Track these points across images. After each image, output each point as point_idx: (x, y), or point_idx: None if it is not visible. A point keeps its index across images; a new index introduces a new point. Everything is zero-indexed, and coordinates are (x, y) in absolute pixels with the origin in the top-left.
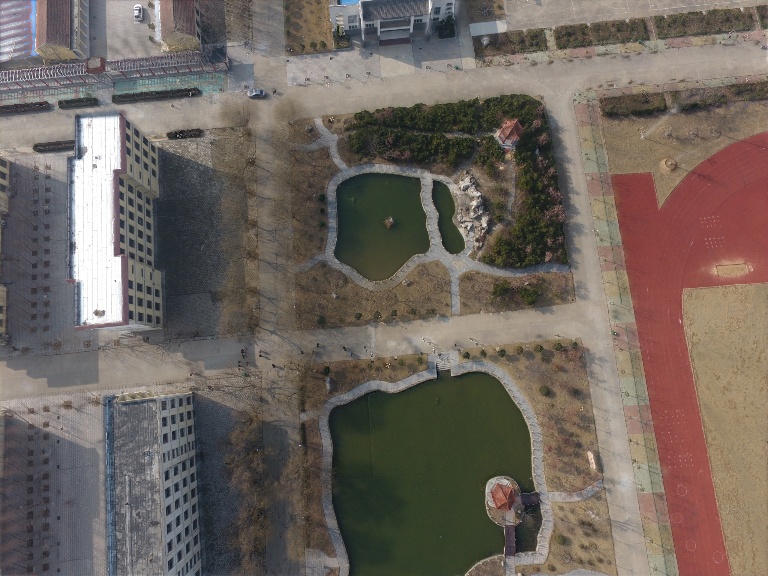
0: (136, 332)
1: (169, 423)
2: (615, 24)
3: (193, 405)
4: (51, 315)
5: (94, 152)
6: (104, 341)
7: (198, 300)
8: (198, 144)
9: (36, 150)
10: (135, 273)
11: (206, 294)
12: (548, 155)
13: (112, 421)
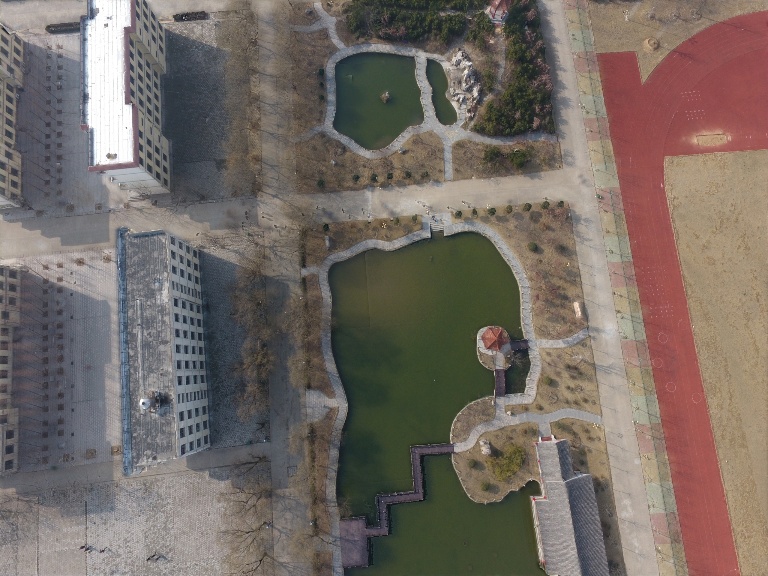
0: (145, 195)
1: (177, 260)
2: None
3: (199, 260)
4: (64, 181)
5: (105, 13)
6: (114, 204)
7: (204, 167)
8: (203, 26)
9: (48, 31)
10: (145, 127)
11: (211, 162)
12: (536, 31)
13: (124, 252)
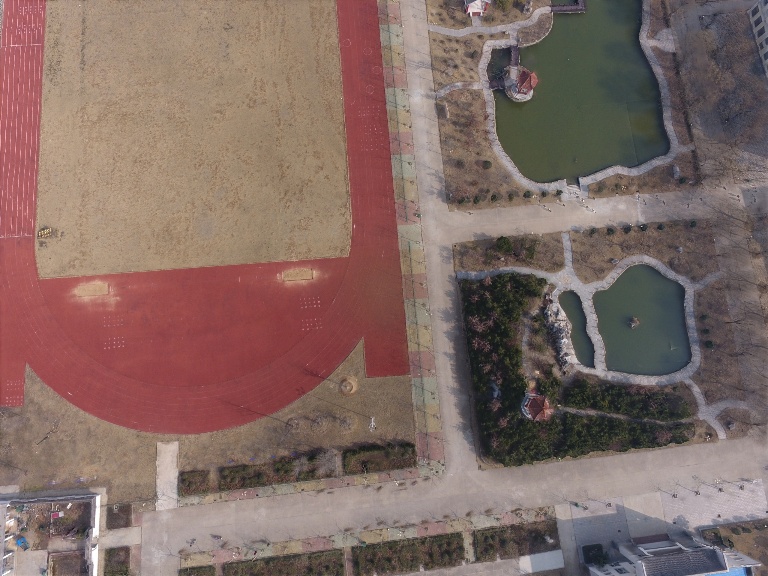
0: None
1: None
2: (391, 570)
3: None
4: None
5: None
6: None
7: None
8: None
9: None
10: None
11: None
12: (486, 389)
13: None
